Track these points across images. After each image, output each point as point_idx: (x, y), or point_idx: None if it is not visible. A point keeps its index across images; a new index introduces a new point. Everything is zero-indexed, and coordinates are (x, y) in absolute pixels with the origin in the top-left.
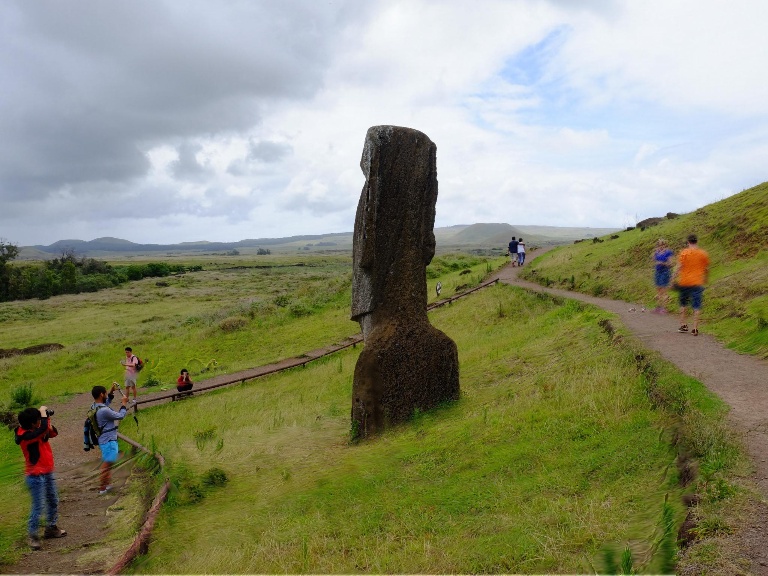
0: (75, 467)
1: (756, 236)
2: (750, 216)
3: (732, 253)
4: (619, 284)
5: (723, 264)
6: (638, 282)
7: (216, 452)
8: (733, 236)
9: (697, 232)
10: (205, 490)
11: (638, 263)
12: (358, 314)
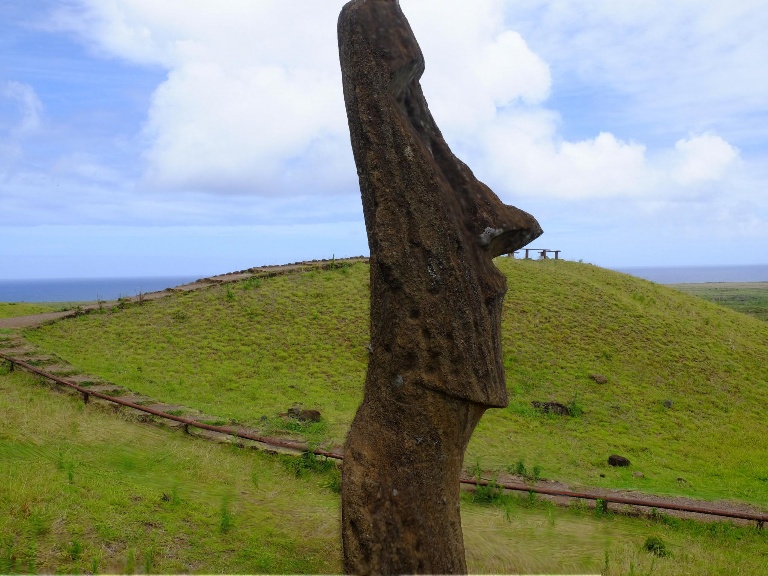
0: (580, 491)
1: None
2: None
3: None
4: None
5: None
6: None
7: (480, 512)
8: None
9: None
10: (303, 474)
11: None
12: None
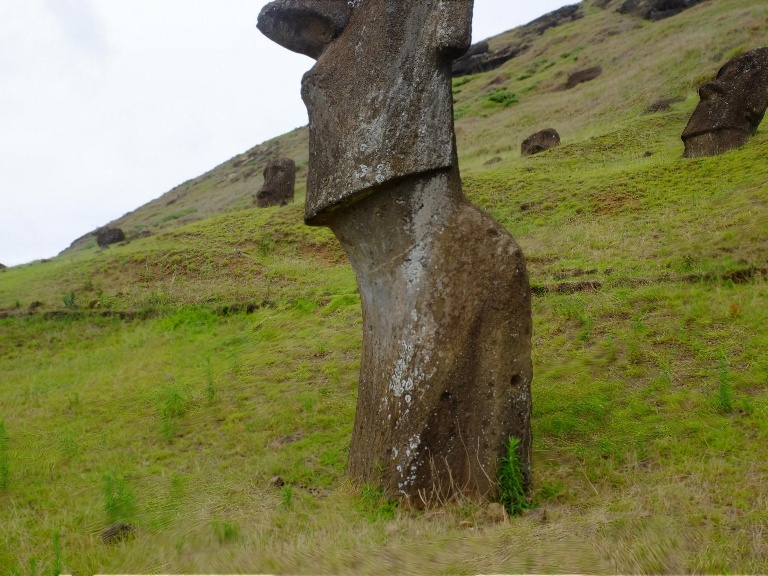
0: None
1: (334, 245)
2: (294, 231)
3: (318, 261)
4: (190, 295)
5: (329, 269)
6: (227, 290)
7: None
8: (294, 248)
9: (222, 247)
10: None
11: (175, 276)
12: (420, 170)
